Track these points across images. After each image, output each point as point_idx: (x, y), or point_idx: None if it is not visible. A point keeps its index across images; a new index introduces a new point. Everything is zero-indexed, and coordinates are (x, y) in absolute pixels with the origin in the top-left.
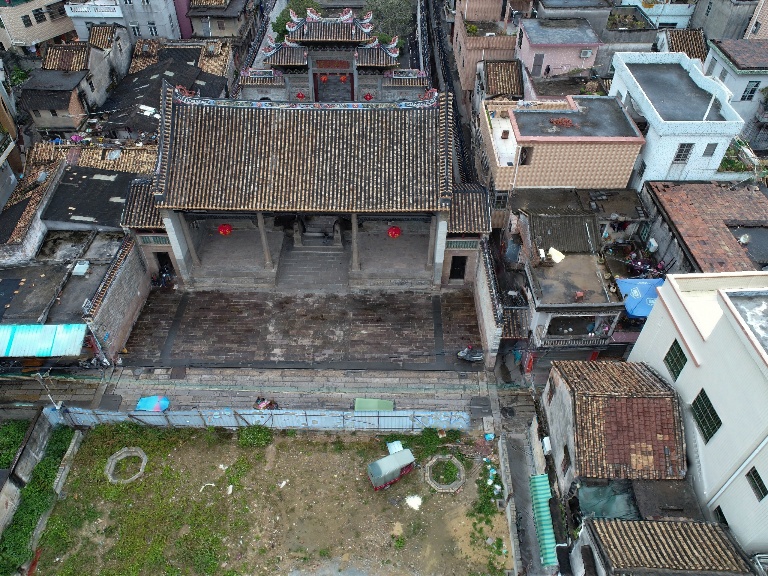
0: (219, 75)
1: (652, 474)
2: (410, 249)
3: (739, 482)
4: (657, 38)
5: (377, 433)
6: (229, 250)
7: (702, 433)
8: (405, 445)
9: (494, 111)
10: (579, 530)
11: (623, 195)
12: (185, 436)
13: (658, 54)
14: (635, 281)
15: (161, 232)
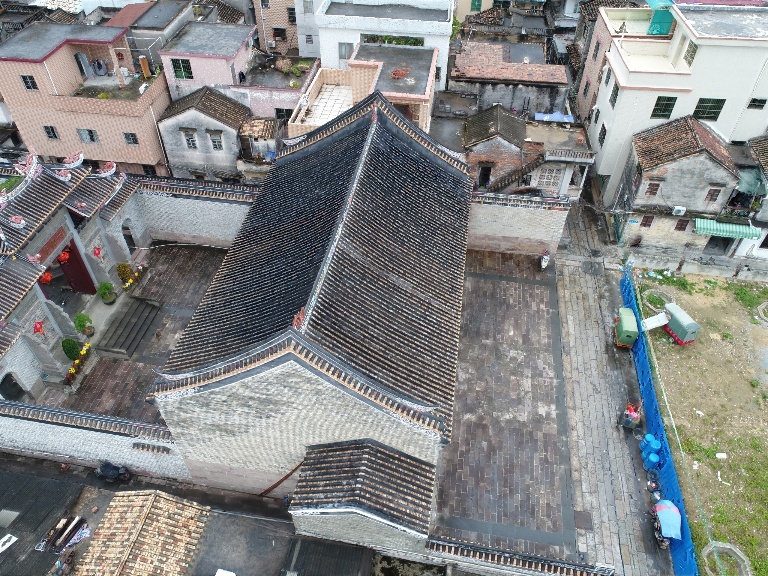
0: None
1: (728, 153)
2: None
3: (744, 116)
4: None
5: None
6: None
7: (708, 120)
8: (641, 319)
9: None
10: (755, 202)
11: (444, 98)
12: None
13: None
14: None
15: None
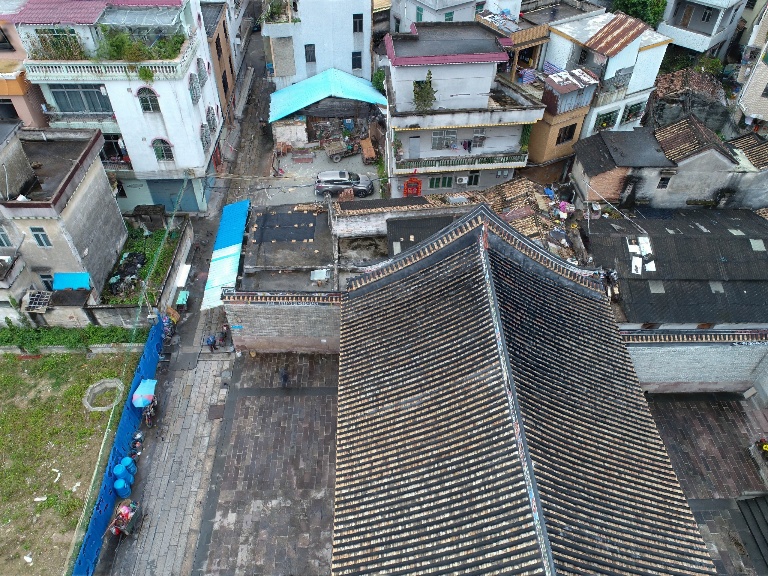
0: None
1: None
2: None
3: None
4: None
5: None
6: None
7: None
8: None
9: None
10: None
11: None
12: None
13: None
14: None
15: None
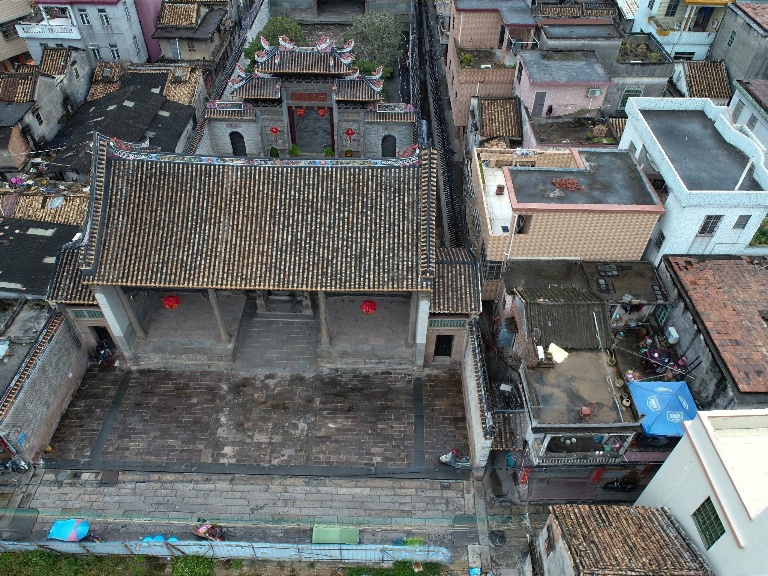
0: (186, 104)
1: None
2: (389, 319)
3: None
4: None
5: (340, 565)
6: (181, 319)
7: None
8: None
9: (488, 160)
10: None
11: (637, 269)
12: (108, 568)
13: (678, 100)
14: (652, 386)
15: (96, 305)
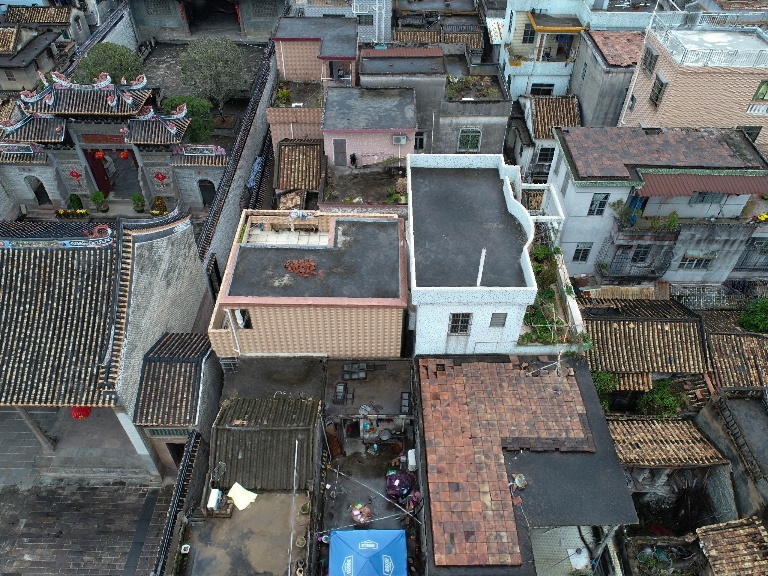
0: None
1: None
2: None
3: None
4: (524, 105)
5: None
6: None
7: None
8: None
9: (261, 223)
10: None
11: (391, 370)
12: None
13: (466, 157)
14: (359, 538)
15: None
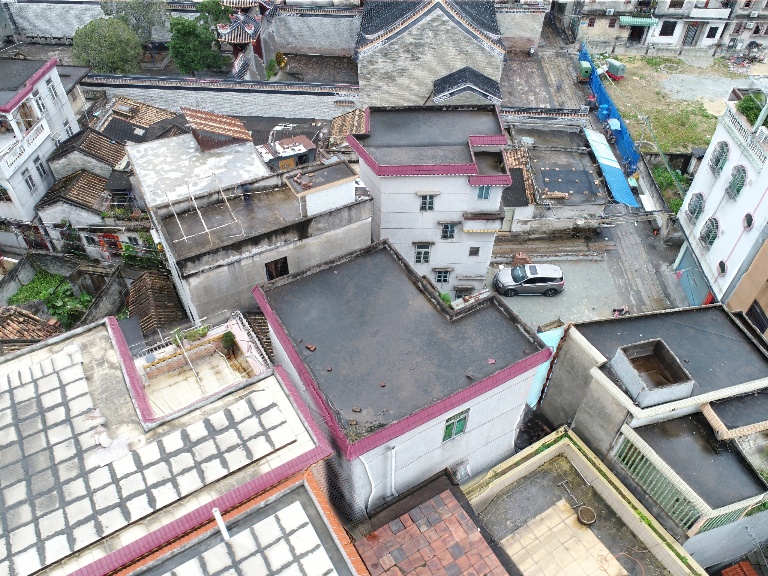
0: None
1: None
2: None
3: None
4: None
5: None
6: None
7: None
8: None
9: None
10: (653, 2)
11: None
12: None
13: None
14: None
15: None
